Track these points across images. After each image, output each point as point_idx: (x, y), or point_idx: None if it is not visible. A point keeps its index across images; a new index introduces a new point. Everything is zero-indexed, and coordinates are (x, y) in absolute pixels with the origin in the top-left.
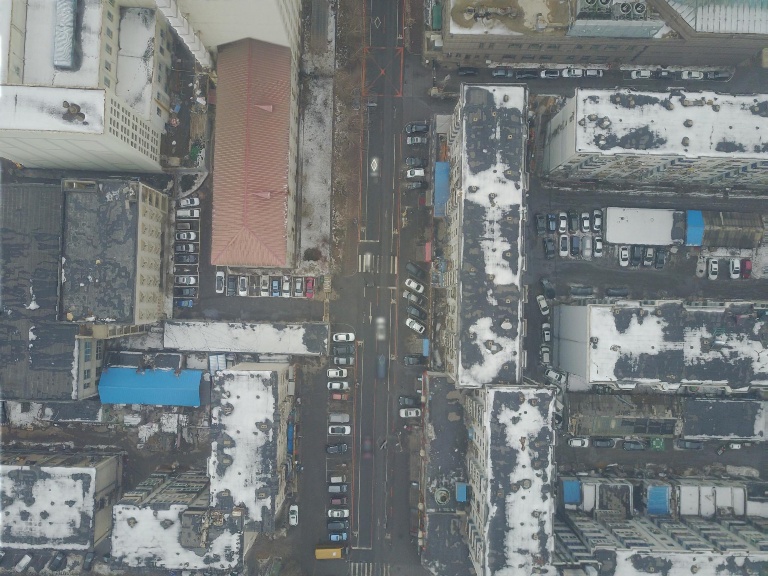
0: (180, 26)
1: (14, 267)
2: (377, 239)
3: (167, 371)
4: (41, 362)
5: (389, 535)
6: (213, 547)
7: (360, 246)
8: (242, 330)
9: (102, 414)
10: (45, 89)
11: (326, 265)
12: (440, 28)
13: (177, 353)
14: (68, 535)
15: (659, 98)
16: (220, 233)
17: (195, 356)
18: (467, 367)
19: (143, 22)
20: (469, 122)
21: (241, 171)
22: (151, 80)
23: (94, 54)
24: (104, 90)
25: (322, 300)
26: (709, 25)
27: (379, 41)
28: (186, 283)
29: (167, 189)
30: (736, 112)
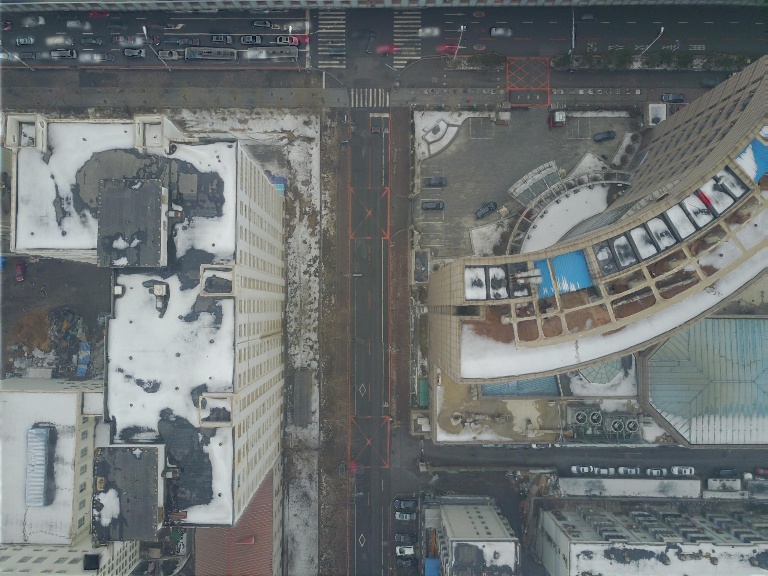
0: None
1: None
2: None
3: None
4: None
5: None
6: None
7: None
8: None
9: None
10: None
11: None
12: (427, 405)
13: None
14: None
15: (655, 552)
16: None
17: None
18: None
19: None
20: None
21: None
22: None
23: (67, 486)
24: None
25: None
26: (704, 437)
27: (364, 410)
28: None
29: (148, 571)
30: (735, 565)
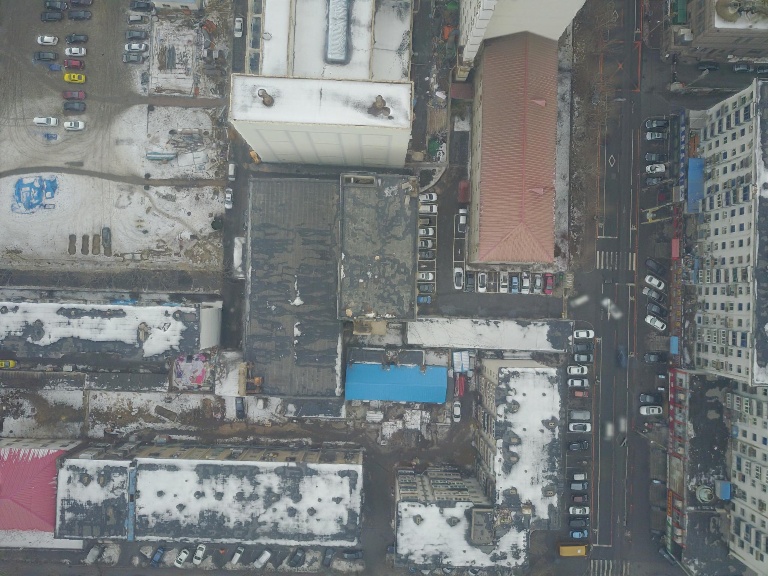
0: (488, 19)
1: (278, 262)
2: (615, 235)
3: (412, 367)
4: (306, 358)
5: (629, 532)
6: (500, 545)
7: (598, 242)
8: (486, 326)
9: (345, 410)
10: (350, 83)
11: (566, 261)
12: (685, 22)
13: (420, 349)
14: (335, 532)
15: None
16: (490, 229)
17: (434, 352)
18: (763, 365)
19: (398, 15)
20: (764, 118)
21: (518, 166)
22: (407, 74)
23: (364, 47)
24: (410, 84)
25: (560, 297)
26: None
27: (617, 35)
28: (425, 279)
29: None
30: None
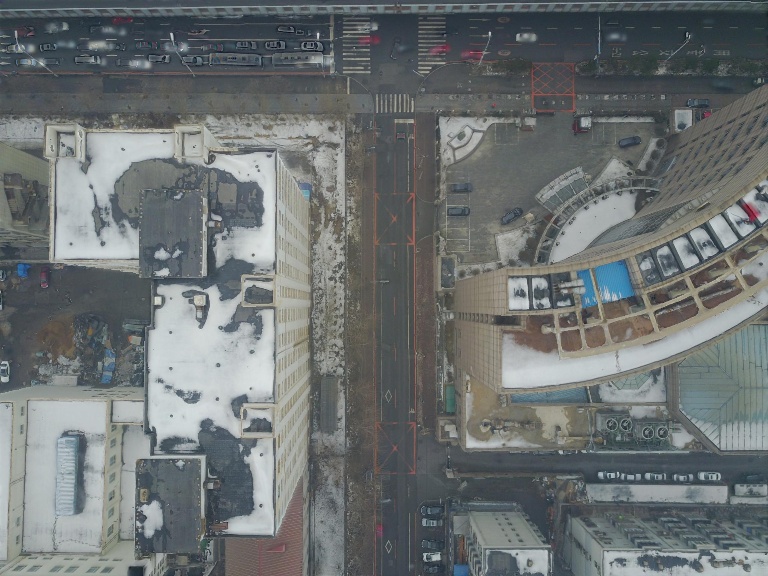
0: None
1: None
2: None
3: None
4: None
5: None
6: None
7: None
8: None
9: None
10: None
11: None
12: (454, 411)
13: None
14: None
15: (688, 559)
16: None
17: None
18: None
19: None
20: None
21: None
22: None
23: (97, 495)
24: None
25: None
26: (734, 443)
27: (391, 417)
28: None
29: None
30: (767, 572)
